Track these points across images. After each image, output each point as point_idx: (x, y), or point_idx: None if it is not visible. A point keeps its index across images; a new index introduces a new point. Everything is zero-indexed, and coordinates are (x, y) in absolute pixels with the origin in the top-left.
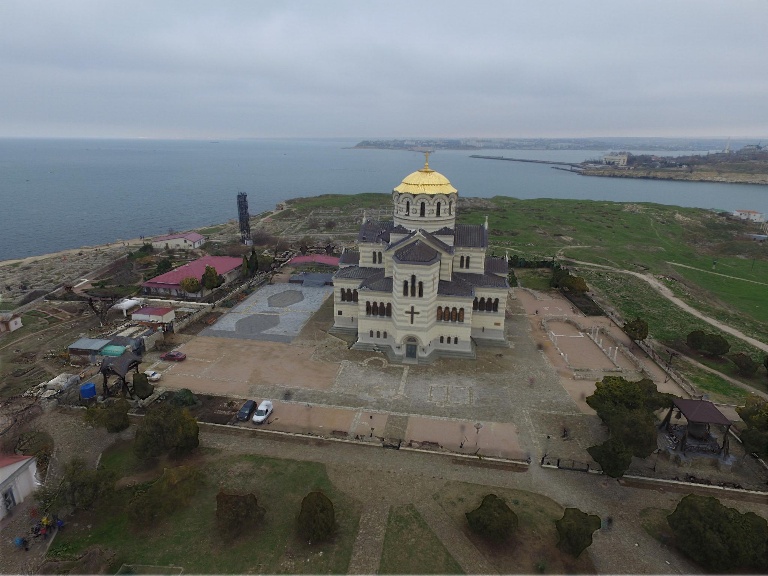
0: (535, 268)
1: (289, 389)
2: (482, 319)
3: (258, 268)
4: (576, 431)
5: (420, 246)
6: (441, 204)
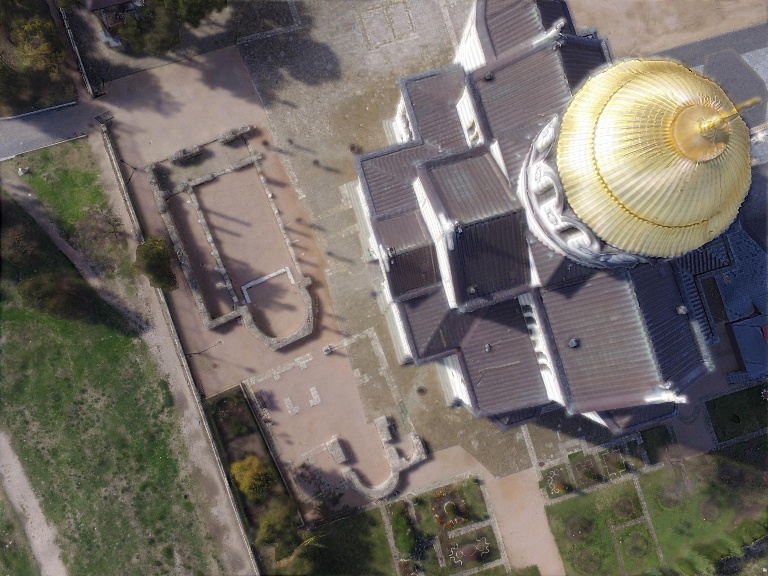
0: None
1: None
2: None
3: None
4: (242, 4)
5: (526, 6)
6: None
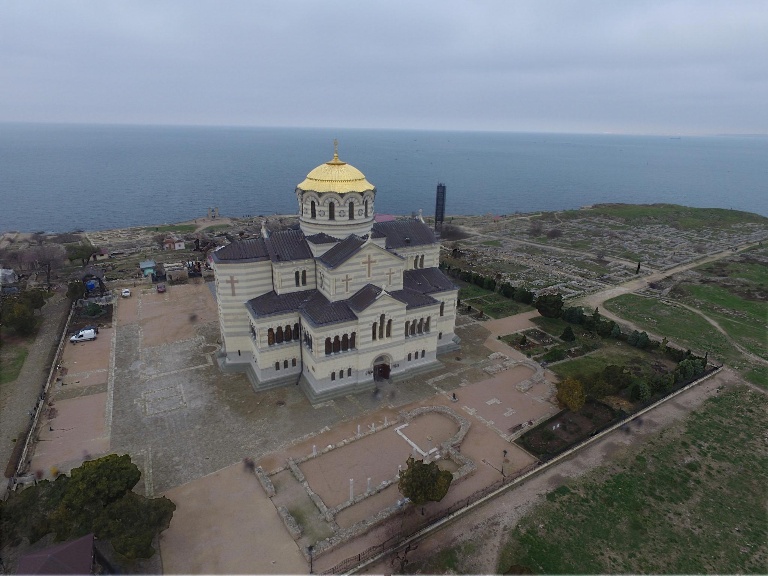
0: (658, 357)
1: (136, 334)
2: (306, 355)
3: None
4: None
5: (242, 243)
6: (315, 204)
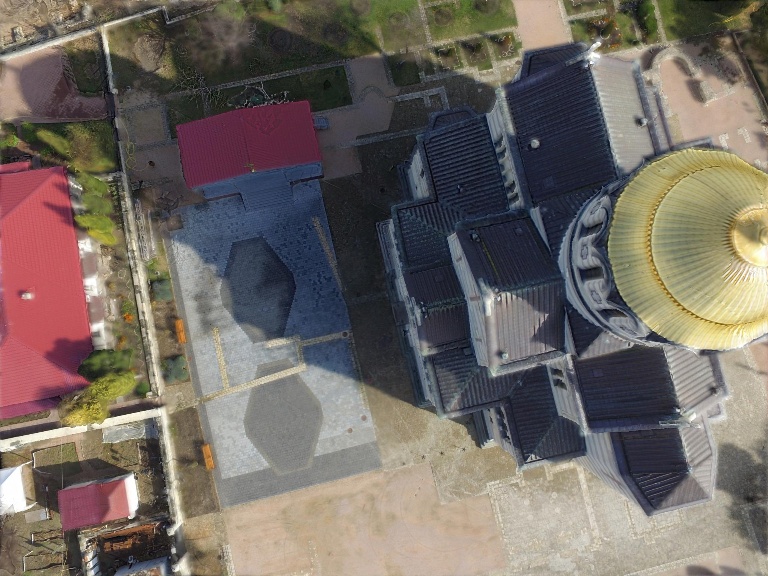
0: None
1: None
2: None
3: (97, 172)
4: None
5: (693, 462)
6: None
